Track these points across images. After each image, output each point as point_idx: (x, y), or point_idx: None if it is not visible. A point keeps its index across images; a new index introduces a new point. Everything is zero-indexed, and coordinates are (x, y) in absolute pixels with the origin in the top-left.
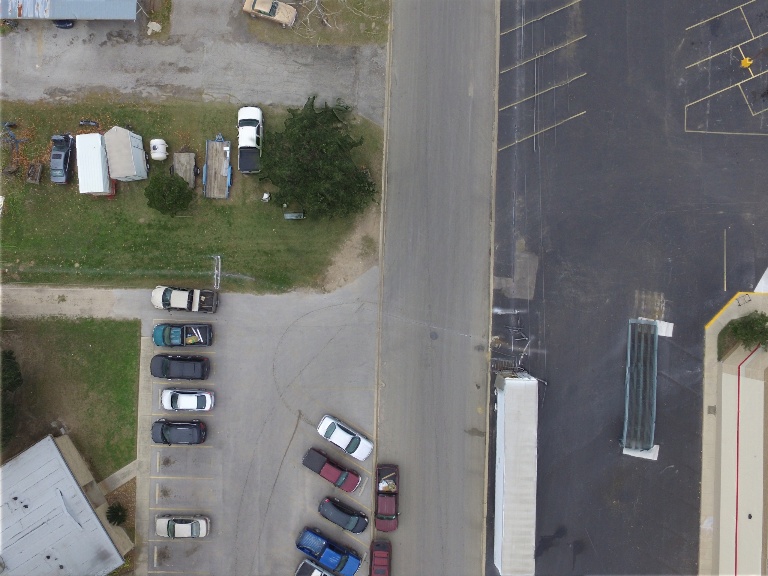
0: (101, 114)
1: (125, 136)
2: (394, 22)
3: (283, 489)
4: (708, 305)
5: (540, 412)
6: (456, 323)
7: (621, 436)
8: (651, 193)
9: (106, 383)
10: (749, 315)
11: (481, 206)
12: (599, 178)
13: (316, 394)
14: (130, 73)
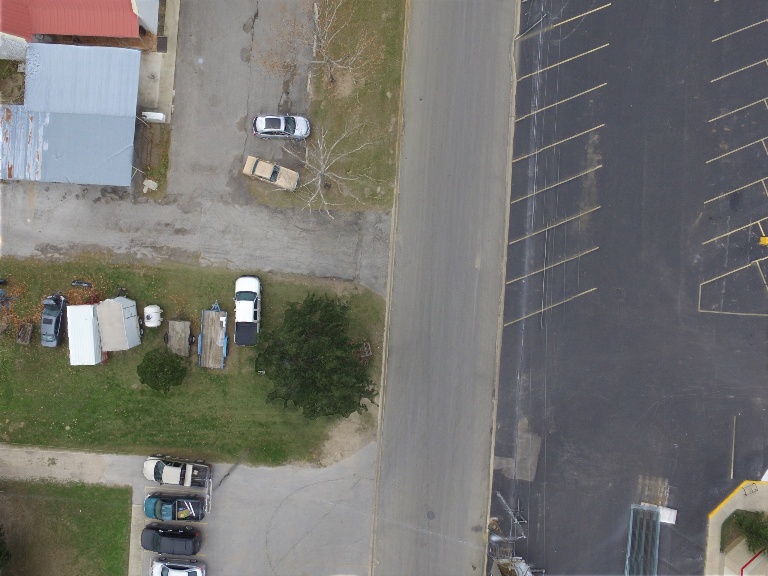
0: (94, 274)
1: (118, 309)
2: (400, 186)
3: None
4: (713, 493)
5: None
6: (454, 503)
7: None
8: (660, 375)
9: (96, 549)
10: (755, 513)
11: (484, 383)
12: (607, 359)
13: (309, 569)
14: (124, 232)
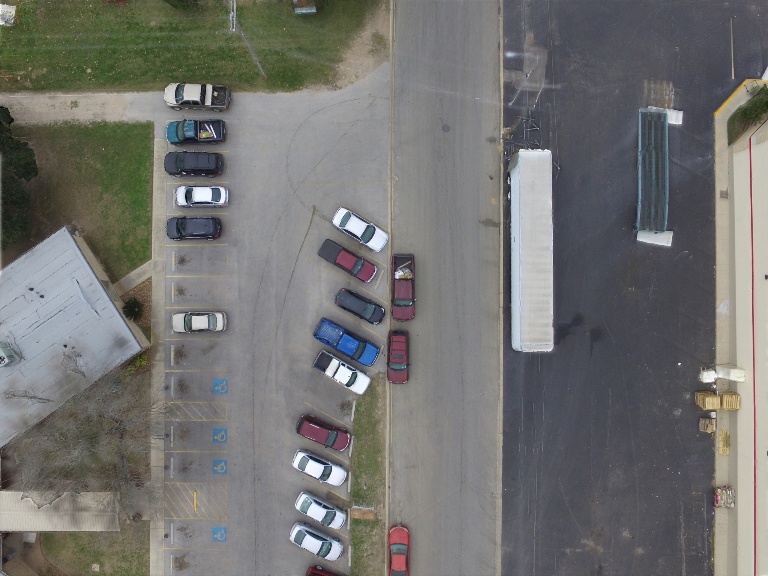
0: None
1: None
2: None
3: (299, 284)
4: (717, 92)
5: (554, 182)
6: (468, 115)
7: (635, 220)
8: None
9: (120, 185)
10: (758, 92)
11: (489, 1)
12: None
13: (330, 189)
14: None
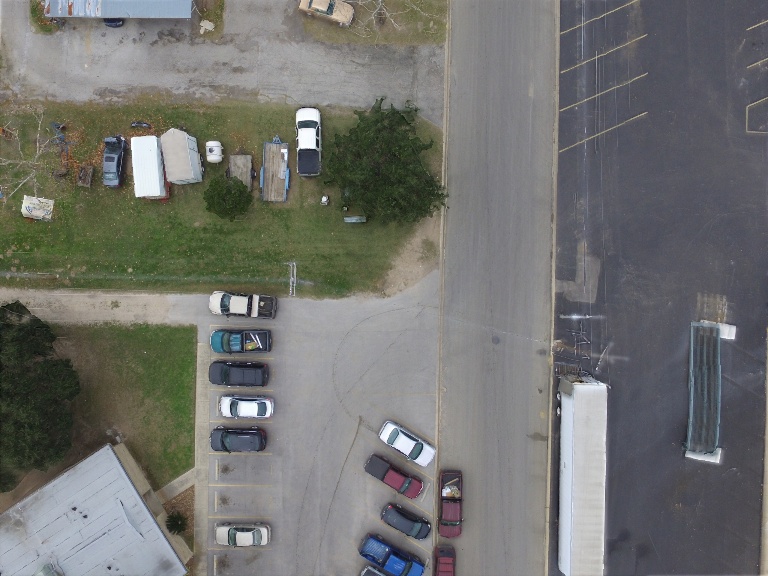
0: (153, 115)
1: (182, 138)
2: (452, 21)
3: (344, 496)
4: None
5: (609, 417)
6: (518, 327)
7: (684, 439)
8: (713, 195)
9: (162, 390)
10: None
11: (542, 208)
12: (661, 180)
13: (377, 400)
14: (183, 73)
